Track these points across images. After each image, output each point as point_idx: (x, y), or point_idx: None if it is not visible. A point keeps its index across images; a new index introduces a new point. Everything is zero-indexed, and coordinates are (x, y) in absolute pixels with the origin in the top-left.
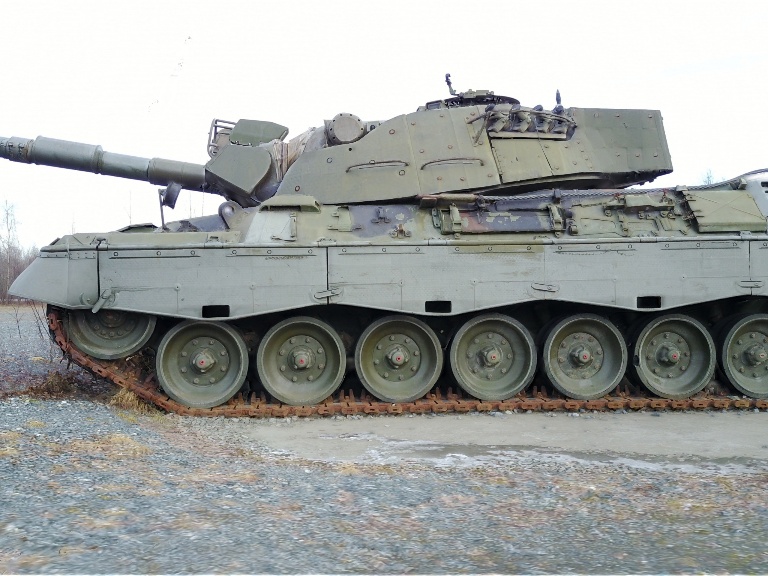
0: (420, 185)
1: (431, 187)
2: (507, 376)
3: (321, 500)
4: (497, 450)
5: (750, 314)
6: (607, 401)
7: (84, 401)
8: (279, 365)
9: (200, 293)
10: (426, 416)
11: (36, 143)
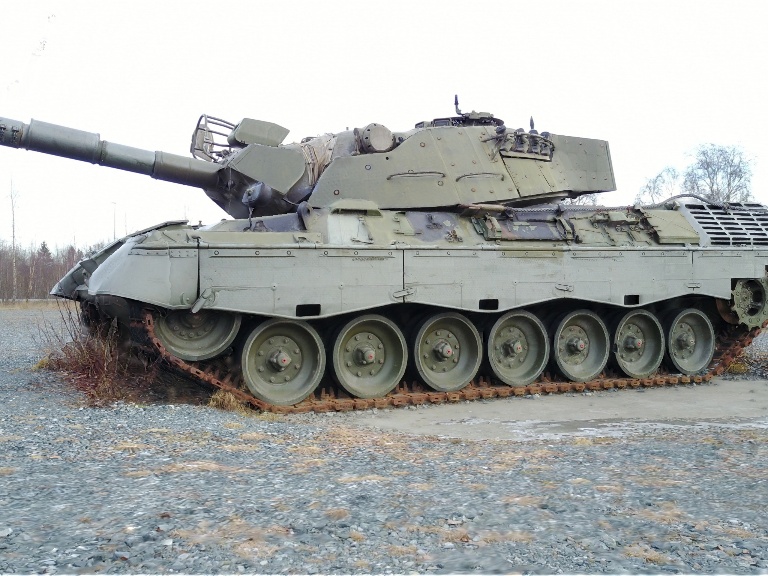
0: (459, 195)
1: (468, 197)
2: (524, 364)
3: None
4: (603, 423)
5: (684, 309)
6: (600, 382)
7: (185, 404)
8: (346, 361)
9: (295, 292)
10: (478, 402)
11: (33, 127)
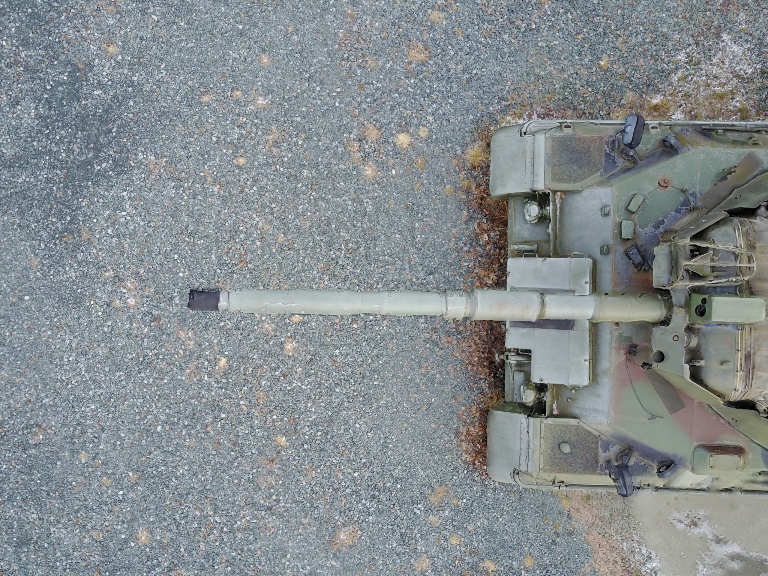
0: None
1: None
2: None
3: None
4: (767, 572)
5: None
6: None
7: None
8: None
9: None
10: None
11: None
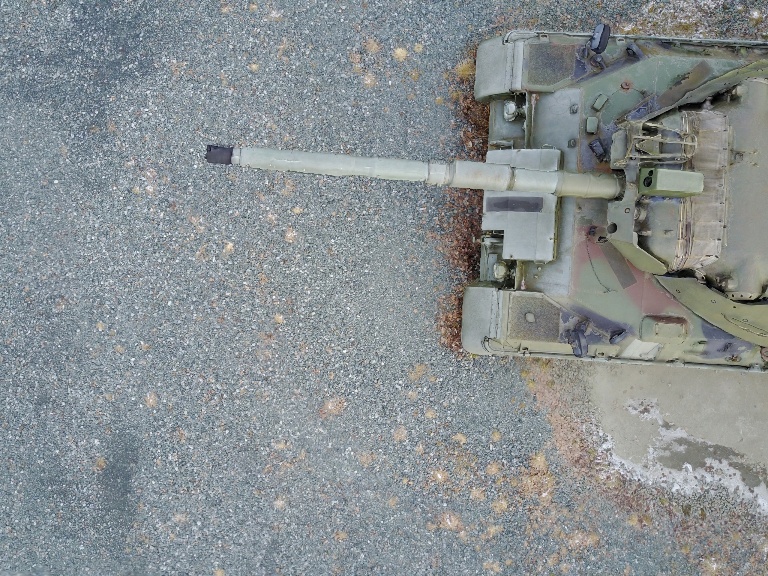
0: None
1: None
2: None
3: (618, 571)
4: (711, 457)
5: None
6: None
7: None
8: None
9: None
10: None
11: None
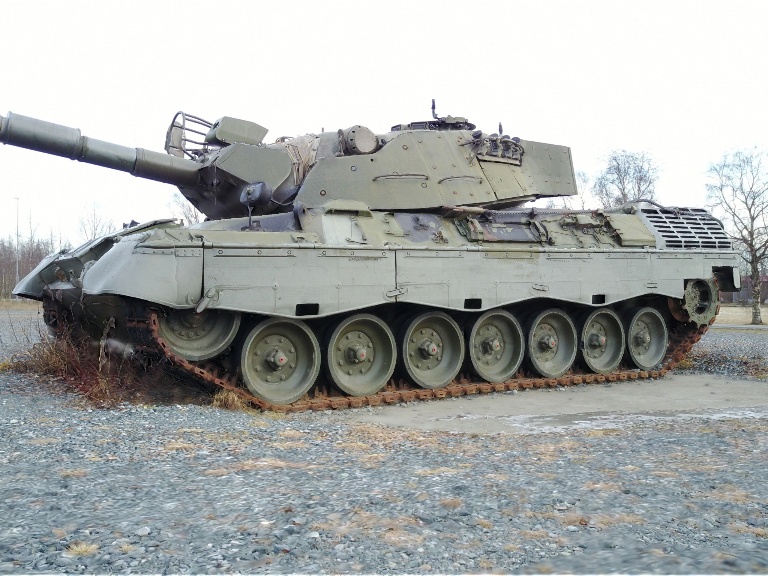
0: (442, 197)
1: (451, 200)
2: (501, 362)
3: None
4: (592, 416)
5: (641, 308)
6: (570, 378)
7: None
8: (338, 360)
9: (295, 292)
10: (463, 398)
11: (12, 121)
